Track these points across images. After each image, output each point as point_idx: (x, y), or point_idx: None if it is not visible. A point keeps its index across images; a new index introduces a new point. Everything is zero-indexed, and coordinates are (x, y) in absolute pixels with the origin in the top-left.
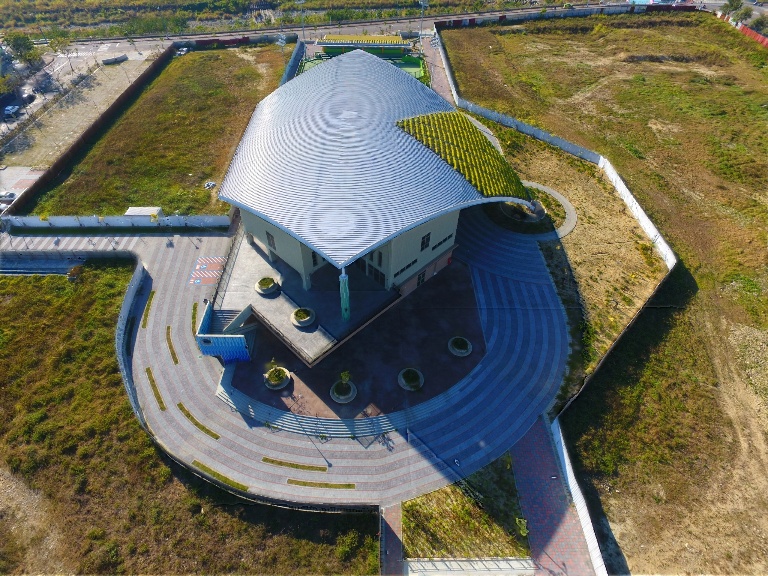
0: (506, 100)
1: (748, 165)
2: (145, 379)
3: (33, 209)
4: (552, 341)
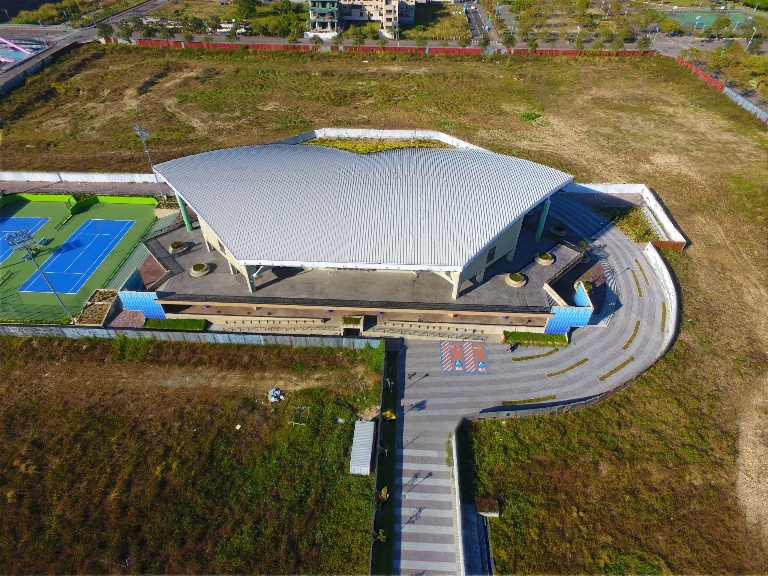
0: (185, 155)
1: (334, 95)
2: (612, 378)
3: None
4: None
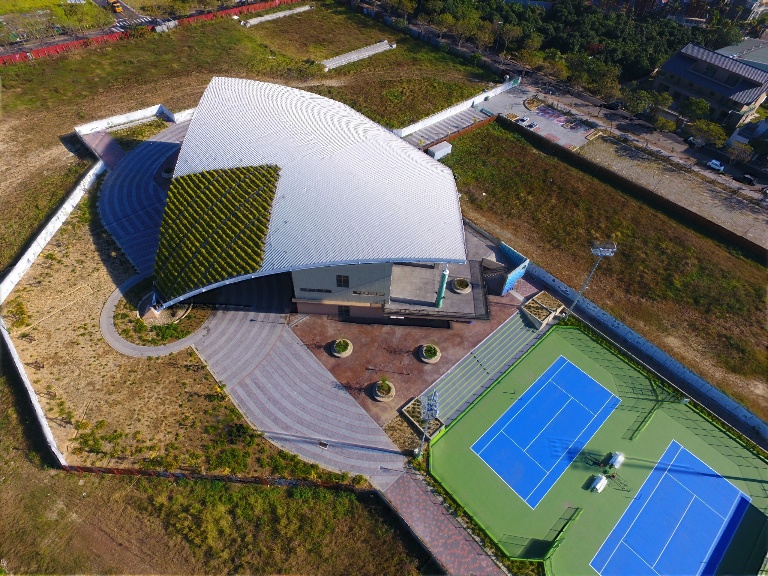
0: None
1: None
2: None
3: (507, 130)
4: (111, 204)
